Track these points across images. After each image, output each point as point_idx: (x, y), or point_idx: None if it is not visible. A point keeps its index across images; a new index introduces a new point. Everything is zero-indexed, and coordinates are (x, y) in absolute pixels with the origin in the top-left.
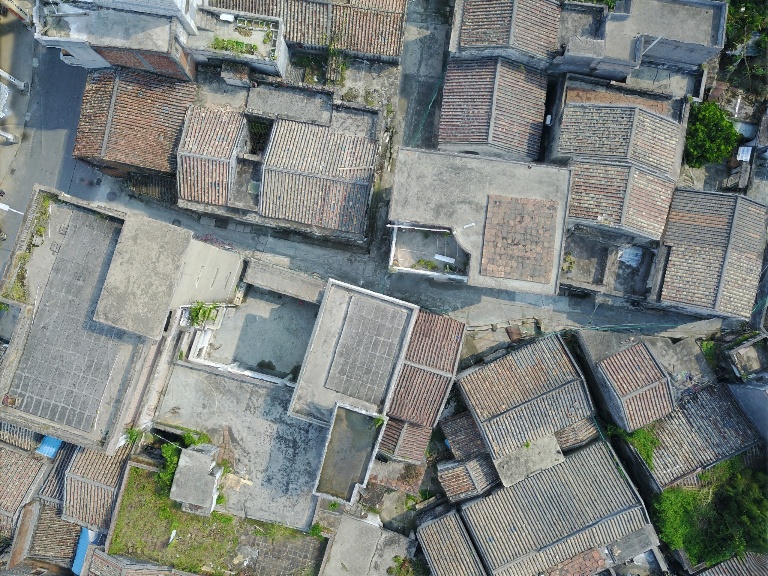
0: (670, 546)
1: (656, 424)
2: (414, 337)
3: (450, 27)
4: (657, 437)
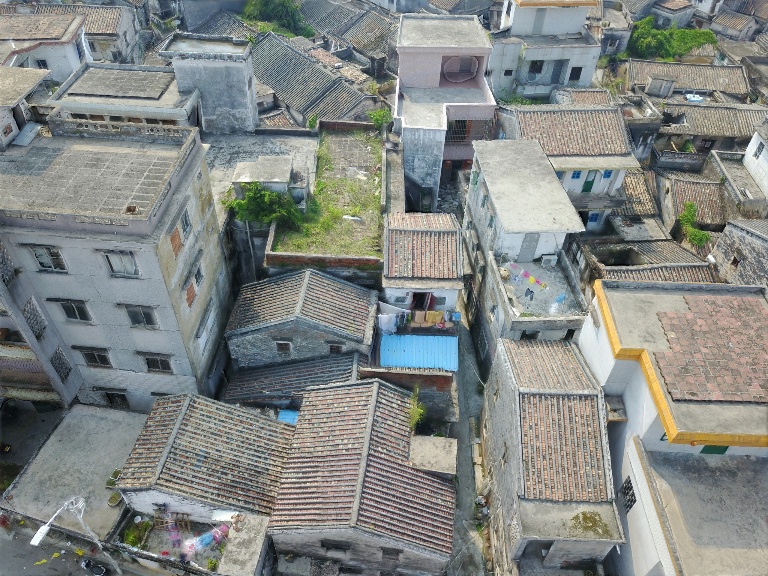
0: None
1: None
2: None
3: None
4: None
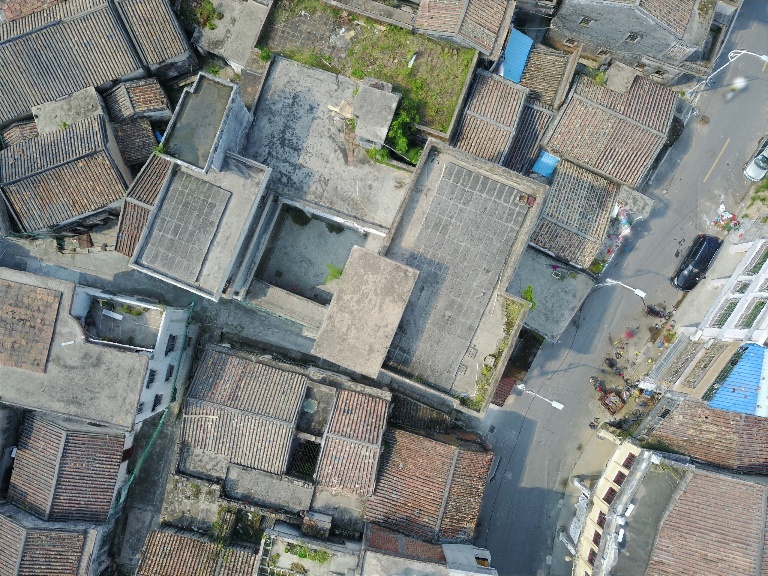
0: None
1: None
2: None
3: (115, 560)
4: None
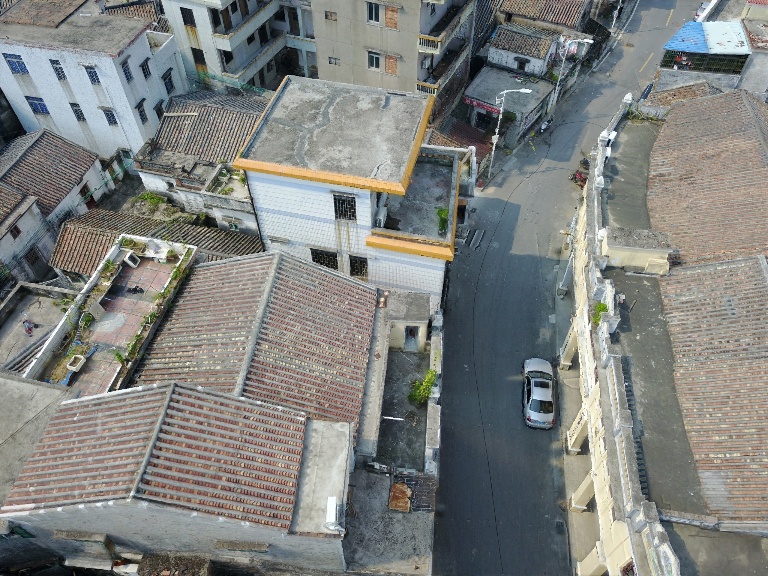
0: None
1: None
2: None
3: None
4: None
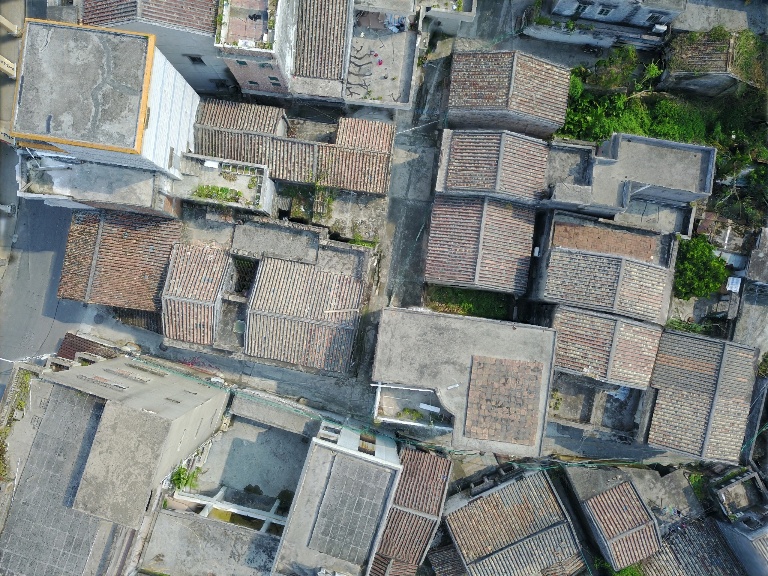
0: None
1: (643, 560)
2: None
3: (438, 150)
4: (644, 573)
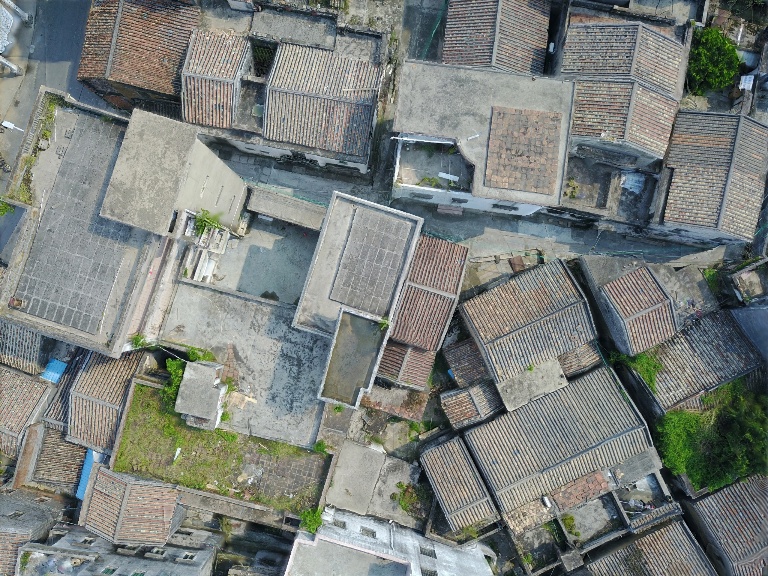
0: (673, 471)
1: (659, 350)
2: (418, 260)
3: None
4: (660, 362)
